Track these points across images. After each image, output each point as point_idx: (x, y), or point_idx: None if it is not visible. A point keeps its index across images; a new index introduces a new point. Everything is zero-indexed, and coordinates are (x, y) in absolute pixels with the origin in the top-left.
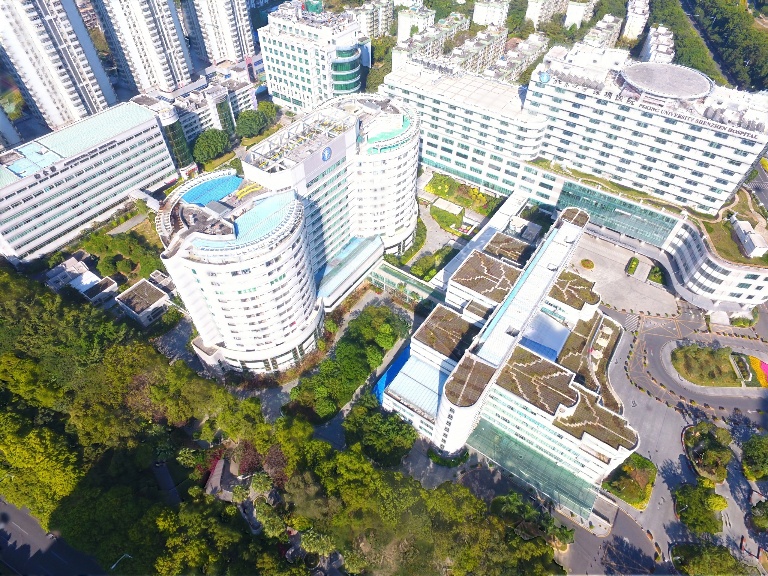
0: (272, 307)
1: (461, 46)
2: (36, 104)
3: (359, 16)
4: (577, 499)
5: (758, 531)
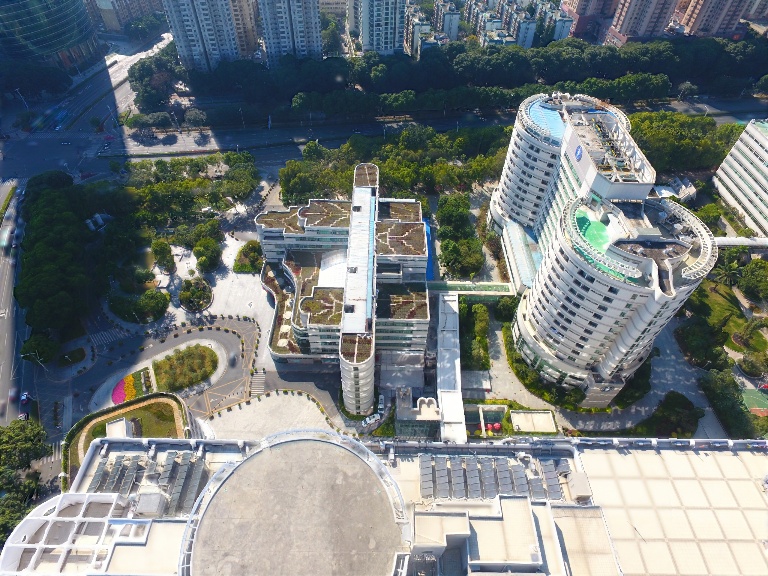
0: None
1: None
2: None
3: None
4: None
5: None
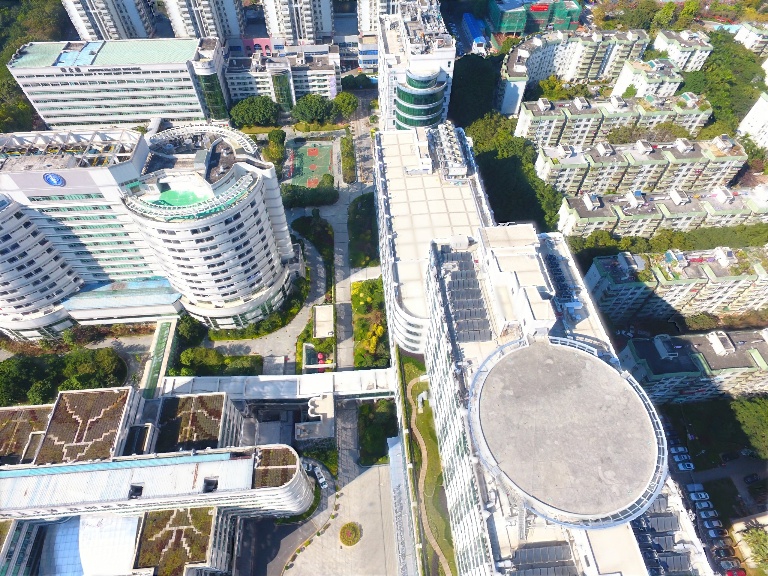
0: None
1: (626, 144)
2: None
3: (575, 44)
4: None
5: None
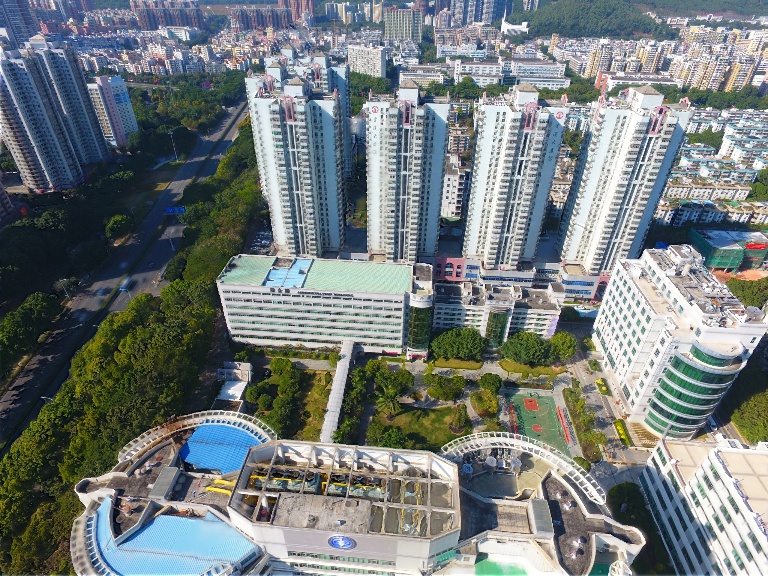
0: None
1: None
2: (367, 228)
3: None
4: None
5: None
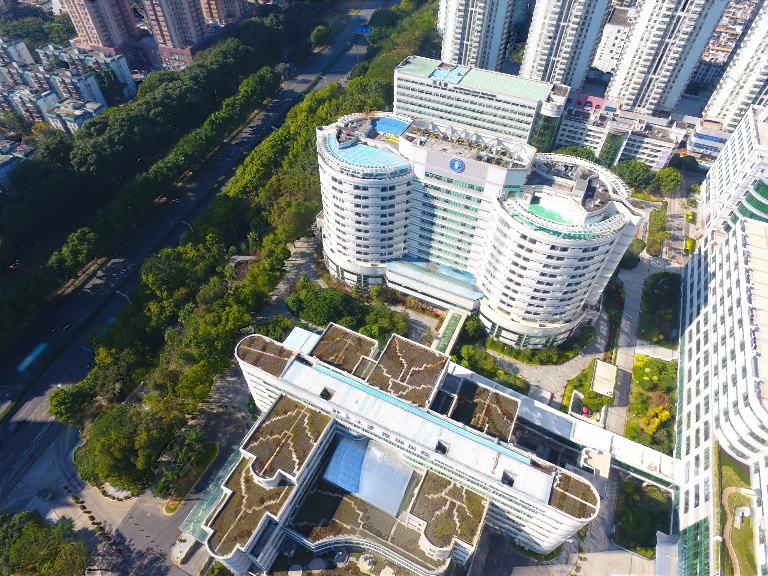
0: (333, 216)
1: None
2: None
3: None
4: (202, 520)
5: None
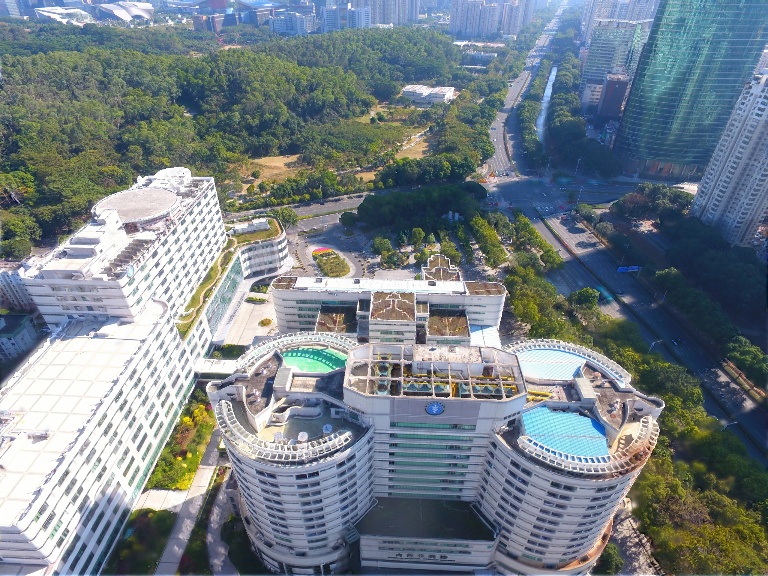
0: None
1: None
2: None
3: None
4: None
5: (419, 249)
